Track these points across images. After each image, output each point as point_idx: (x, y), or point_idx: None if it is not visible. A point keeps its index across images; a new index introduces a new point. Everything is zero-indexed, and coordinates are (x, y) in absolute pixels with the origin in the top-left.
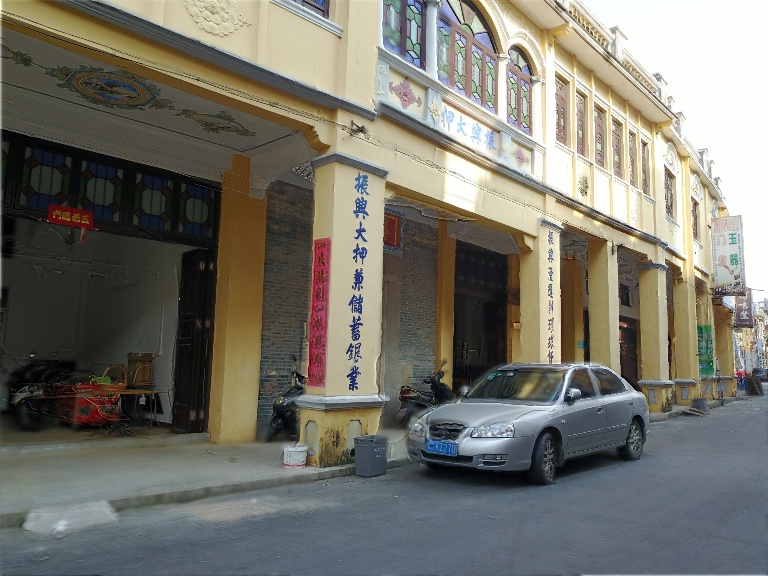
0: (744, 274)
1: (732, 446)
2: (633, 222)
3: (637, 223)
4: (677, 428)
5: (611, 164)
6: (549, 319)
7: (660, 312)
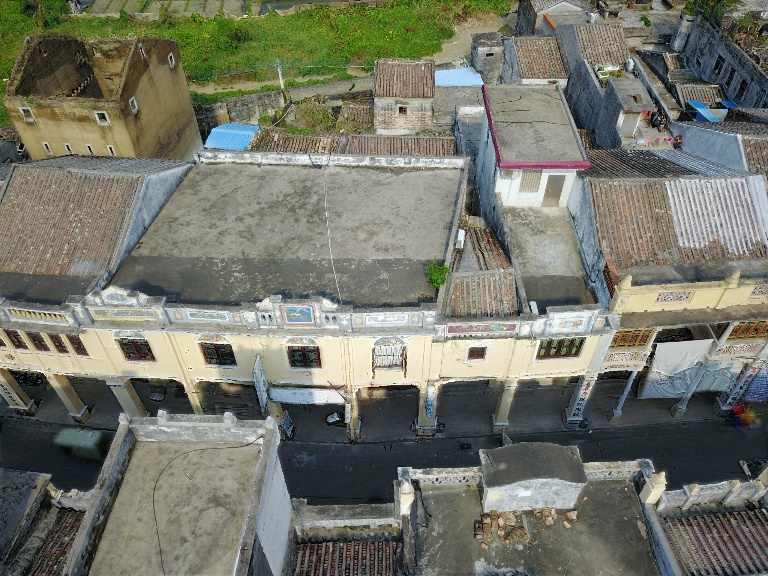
0: (260, 403)
1: (15, 466)
2: (71, 367)
3: (76, 367)
4: (81, 443)
5: (30, 349)
6: (6, 392)
7: (120, 399)
